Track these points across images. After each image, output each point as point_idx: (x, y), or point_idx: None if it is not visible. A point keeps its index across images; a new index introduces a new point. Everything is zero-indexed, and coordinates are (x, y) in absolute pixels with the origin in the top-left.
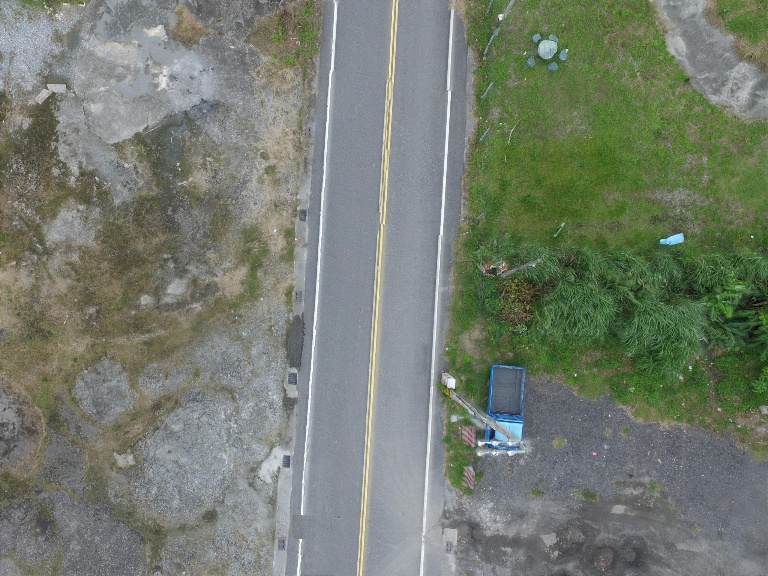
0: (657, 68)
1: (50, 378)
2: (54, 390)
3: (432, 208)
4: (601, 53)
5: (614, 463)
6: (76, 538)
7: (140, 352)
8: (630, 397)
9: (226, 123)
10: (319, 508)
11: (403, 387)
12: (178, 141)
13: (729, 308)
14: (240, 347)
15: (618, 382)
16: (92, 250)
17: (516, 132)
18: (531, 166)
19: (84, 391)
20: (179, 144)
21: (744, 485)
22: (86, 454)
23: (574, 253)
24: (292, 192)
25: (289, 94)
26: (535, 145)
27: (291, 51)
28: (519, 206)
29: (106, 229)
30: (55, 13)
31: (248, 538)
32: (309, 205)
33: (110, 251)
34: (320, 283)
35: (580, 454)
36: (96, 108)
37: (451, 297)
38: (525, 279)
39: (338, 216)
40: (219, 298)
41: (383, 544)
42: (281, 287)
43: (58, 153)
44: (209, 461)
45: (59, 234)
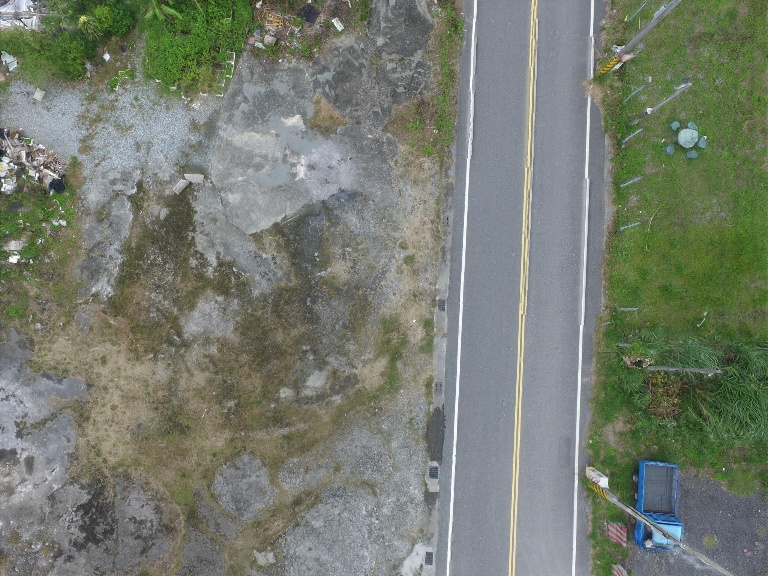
0: None
1: (189, 473)
2: (193, 486)
3: (572, 297)
4: (740, 140)
5: (765, 560)
6: None
7: (279, 446)
8: None
9: (364, 212)
10: None
11: (547, 481)
12: (316, 231)
13: None
14: (381, 440)
15: (767, 476)
16: (230, 342)
17: (656, 220)
18: (672, 254)
19: (223, 487)
20: (317, 234)
21: None
22: (225, 552)
23: (732, 351)
24: (431, 282)
25: (427, 183)
26: (675, 233)
27: (429, 140)
28: (660, 295)
29: (244, 320)
30: (192, 103)
31: None
32: (448, 295)
33: (248, 343)
34: (461, 374)
35: (730, 551)
36: (234, 198)
37: (594, 388)
38: None
39: (478, 306)
40: (359, 390)
41: None
42: (421, 379)
43: (195, 244)
44: (350, 559)
45: (197, 326)
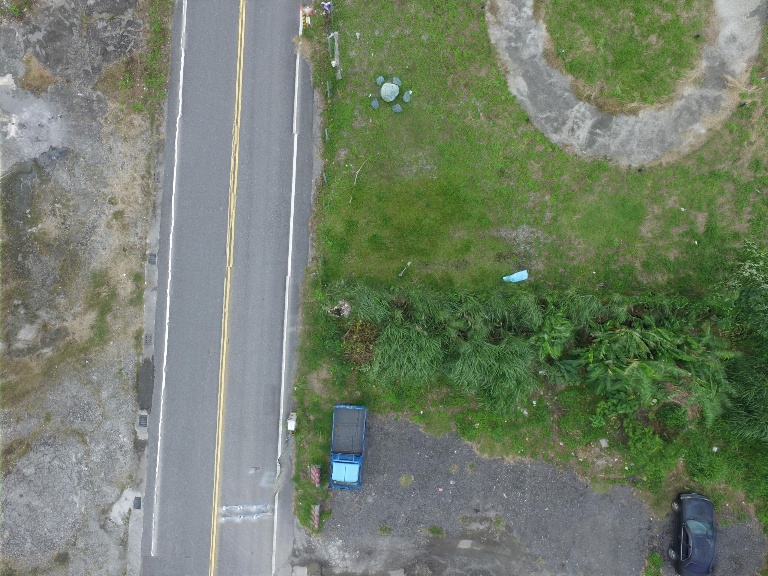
0: (500, 108)
1: None
2: None
3: (280, 250)
4: (444, 94)
5: (460, 498)
6: None
7: None
8: (475, 433)
9: (75, 169)
10: (169, 549)
11: (252, 427)
12: (28, 188)
13: (558, 347)
14: (90, 391)
15: (463, 418)
16: None
17: (362, 173)
18: (377, 206)
19: None
20: (29, 191)
21: (587, 518)
22: None
23: (405, 296)
24: (141, 236)
25: (137, 140)
26: (381, 186)
27: (138, 97)
28: (366, 246)
29: None
30: None
31: None
32: (158, 249)
33: None
34: (169, 326)
35: (427, 490)
36: None
37: (299, 337)
38: None
39: (186, 259)
40: (69, 343)
41: None
42: (131, 330)
43: None
44: (60, 504)
45: None
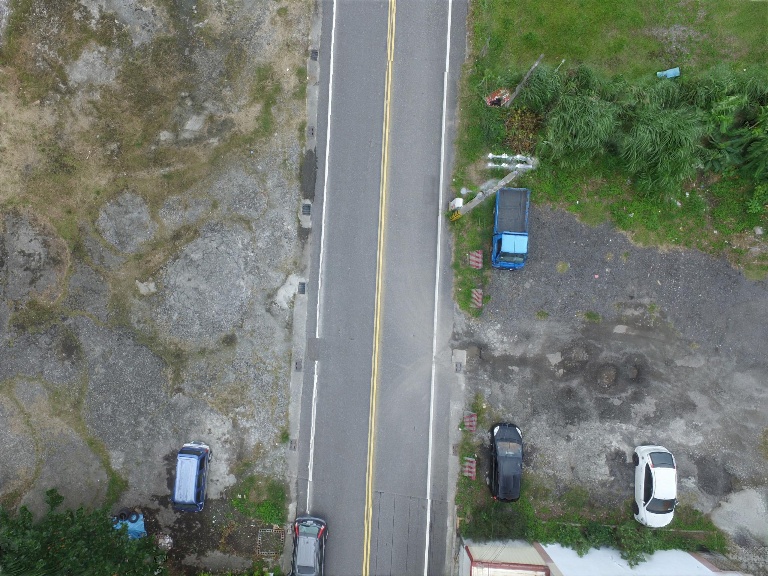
0: None
1: (74, 210)
2: (78, 222)
3: (438, 47)
4: None
5: (615, 285)
6: (101, 361)
7: (160, 185)
8: (630, 222)
9: None
10: (333, 331)
11: (412, 216)
12: None
13: (723, 123)
14: (256, 180)
15: (618, 208)
16: (113, 89)
17: None
18: (532, 6)
19: (107, 222)
20: None
21: (740, 303)
22: (109, 282)
23: (575, 72)
24: (304, 33)
25: None
26: None
27: None
28: (521, 44)
29: (126, 69)
30: None
31: (266, 360)
32: (320, 45)
33: (130, 90)
34: (332, 118)
35: (583, 277)
36: None
37: (457, 130)
38: (528, 109)
39: (348, 55)
40: (235, 134)
41: (395, 364)
42: (294, 123)
43: None
44: (227, 288)
45: (81, 74)
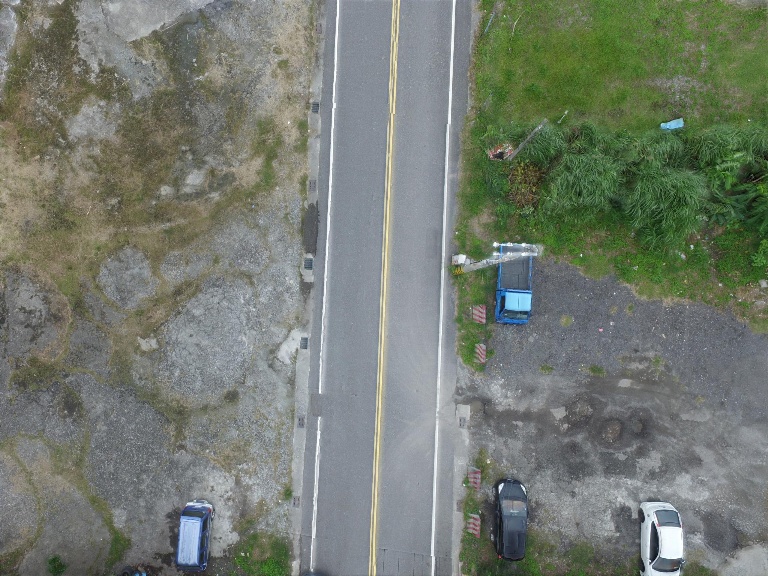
0: None
1: (75, 266)
2: (79, 278)
3: (440, 98)
4: None
5: (620, 339)
6: (103, 419)
7: (161, 240)
8: (634, 275)
9: (240, 20)
10: (336, 387)
11: (415, 270)
12: (194, 38)
13: (728, 179)
14: (257, 234)
15: (622, 261)
16: (113, 143)
17: (519, 24)
18: (535, 56)
19: (108, 278)
20: (195, 41)
21: (746, 357)
22: (111, 339)
23: (578, 128)
24: (304, 85)
25: None
26: (538, 36)
27: None
28: (524, 95)
29: (126, 123)
30: None
31: (268, 417)
32: (321, 97)
33: (130, 144)
34: (333, 172)
35: (587, 331)
36: (114, 7)
37: (460, 183)
38: (531, 162)
39: (349, 107)
40: (236, 188)
41: (399, 420)
42: (296, 176)
43: (78, 51)
44: (229, 344)
45: (81, 129)
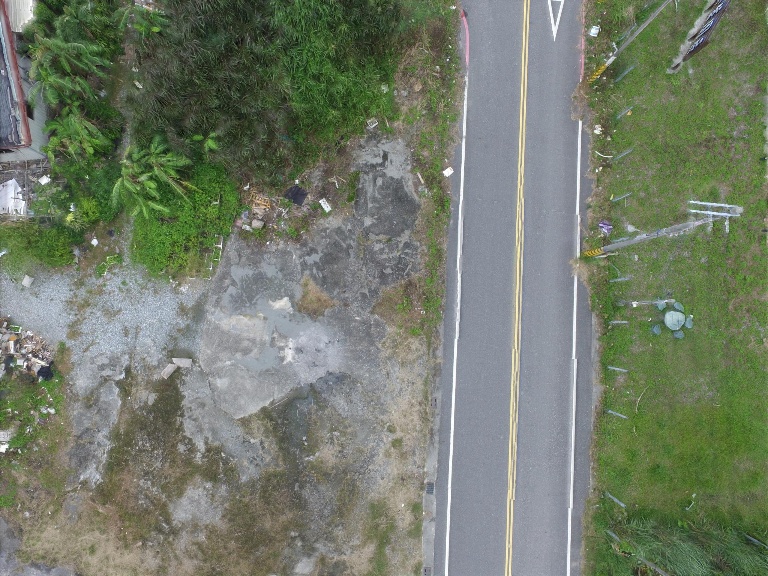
0: None
1: None
2: None
3: (561, 480)
4: (727, 319)
5: None
6: None
7: None
8: None
9: (352, 395)
10: None
11: None
12: (304, 414)
13: None
14: None
15: None
16: (219, 529)
17: (643, 400)
18: (660, 435)
19: None
20: (305, 417)
21: None
22: None
23: (720, 552)
24: (419, 465)
25: (414, 364)
26: (663, 413)
27: (416, 321)
28: (649, 476)
29: (233, 507)
30: (180, 286)
31: None
32: (436, 478)
33: (237, 529)
34: (450, 560)
35: None
36: (222, 382)
37: (583, 573)
38: None
39: (466, 490)
40: None
41: None
42: (410, 564)
43: (184, 428)
44: None
45: (185, 513)
